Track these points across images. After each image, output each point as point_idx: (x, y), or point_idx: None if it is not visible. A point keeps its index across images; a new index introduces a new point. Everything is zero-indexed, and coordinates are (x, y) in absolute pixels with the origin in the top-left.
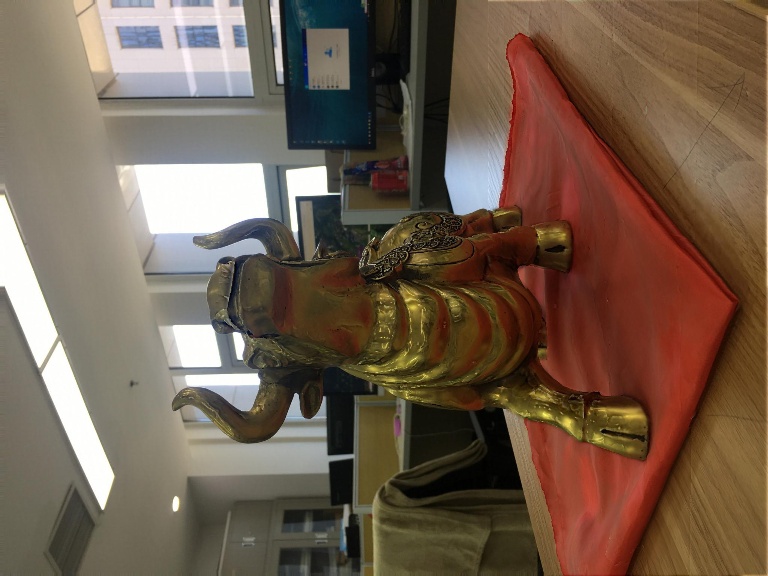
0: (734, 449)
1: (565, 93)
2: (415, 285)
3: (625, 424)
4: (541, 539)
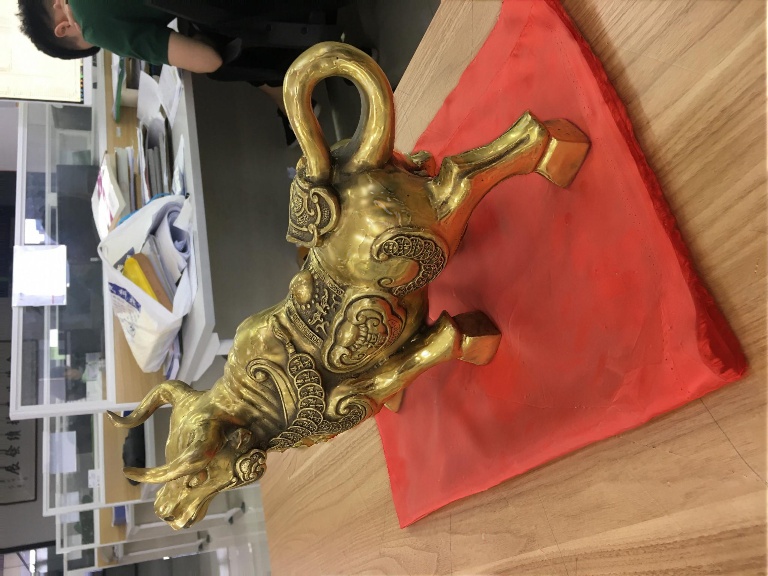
0: (384, 475)
1: None
2: None
3: None
4: None
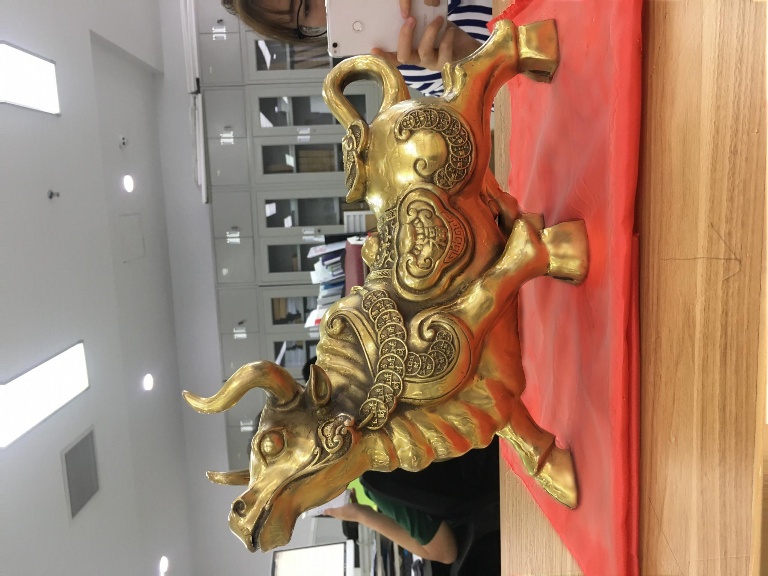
0: None
1: (634, 188)
2: (408, 426)
3: (561, 499)
4: None
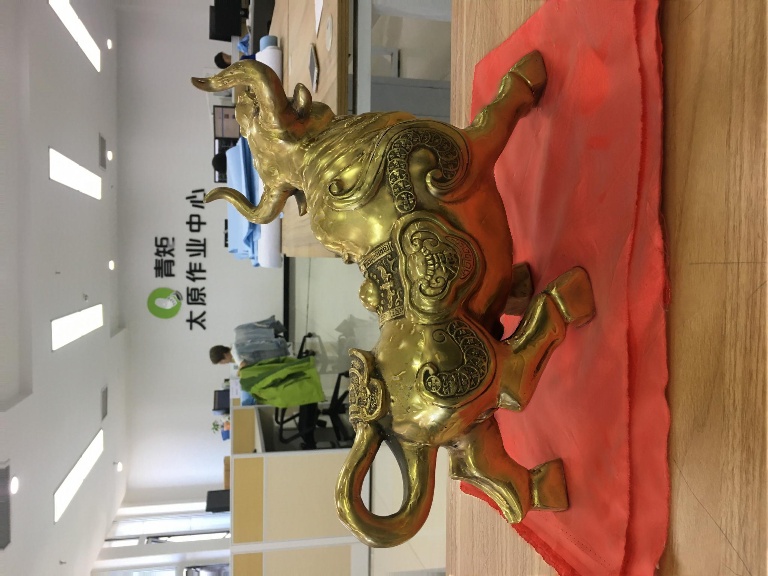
0: None
1: None
2: None
3: None
4: (767, 123)
